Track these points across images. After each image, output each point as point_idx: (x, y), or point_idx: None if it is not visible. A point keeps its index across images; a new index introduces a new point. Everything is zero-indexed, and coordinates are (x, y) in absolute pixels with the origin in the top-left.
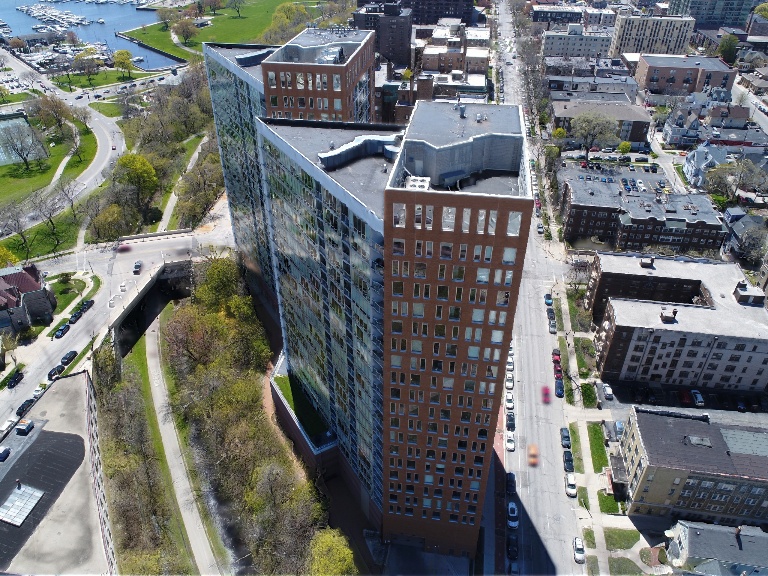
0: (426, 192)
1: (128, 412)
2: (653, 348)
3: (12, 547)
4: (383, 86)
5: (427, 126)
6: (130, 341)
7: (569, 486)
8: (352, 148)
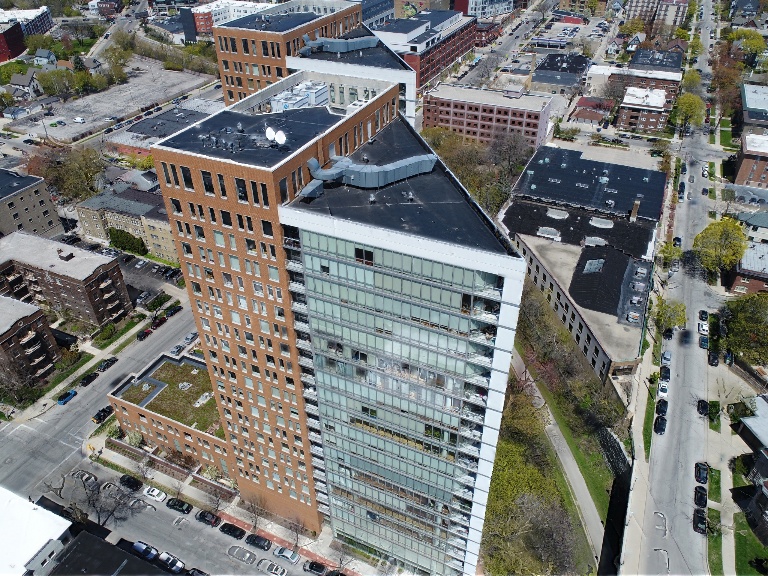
0: None
1: (573, 403)
2: None
3: (586, 255)
4: None
5: None
6: (618, 508)
7: None
8: None
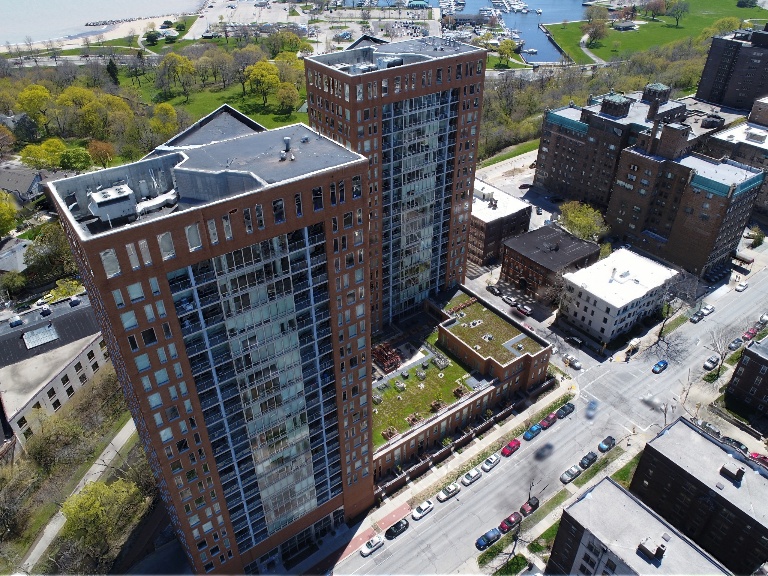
0: (55, 197)
1: None
2: (608, 574)
3: (13, 359)
4: (630, 124)
5: (232, 147)
6: None
7: None
8: None
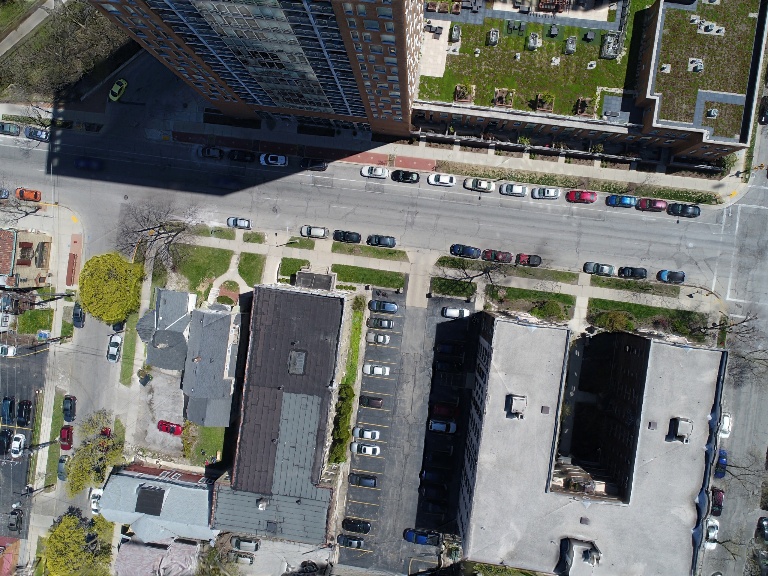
0: None
1: None
2: None
3: None
4: None
5: None
6: None
7: (309, 228)
8: None
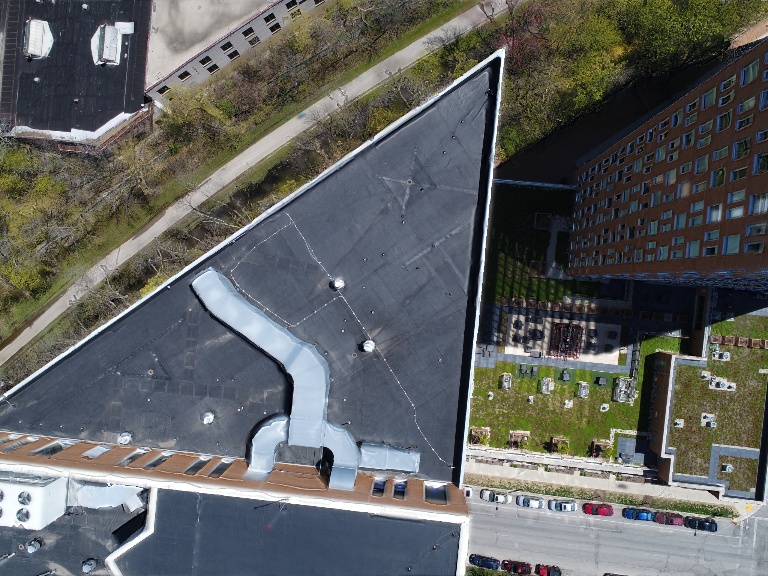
0: None
1: None
2: None
3: None
4: None
5: (254, 542)
6: None
7: None
8: (255, 345)
